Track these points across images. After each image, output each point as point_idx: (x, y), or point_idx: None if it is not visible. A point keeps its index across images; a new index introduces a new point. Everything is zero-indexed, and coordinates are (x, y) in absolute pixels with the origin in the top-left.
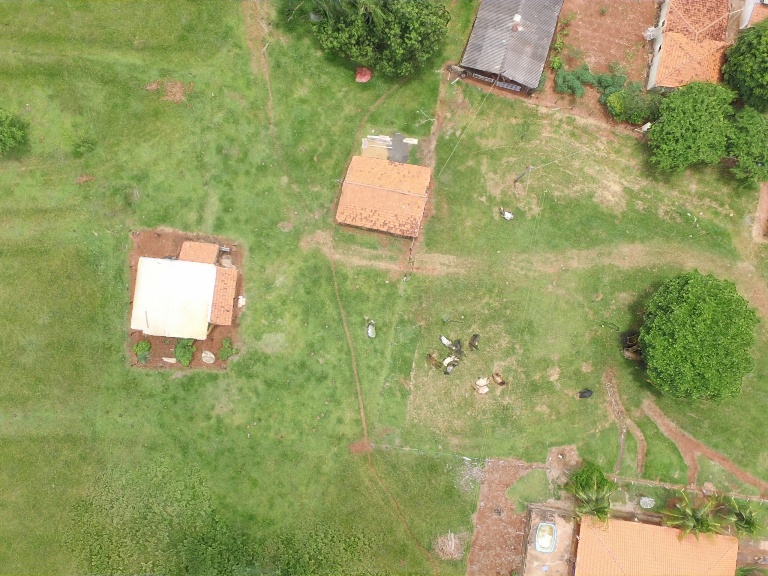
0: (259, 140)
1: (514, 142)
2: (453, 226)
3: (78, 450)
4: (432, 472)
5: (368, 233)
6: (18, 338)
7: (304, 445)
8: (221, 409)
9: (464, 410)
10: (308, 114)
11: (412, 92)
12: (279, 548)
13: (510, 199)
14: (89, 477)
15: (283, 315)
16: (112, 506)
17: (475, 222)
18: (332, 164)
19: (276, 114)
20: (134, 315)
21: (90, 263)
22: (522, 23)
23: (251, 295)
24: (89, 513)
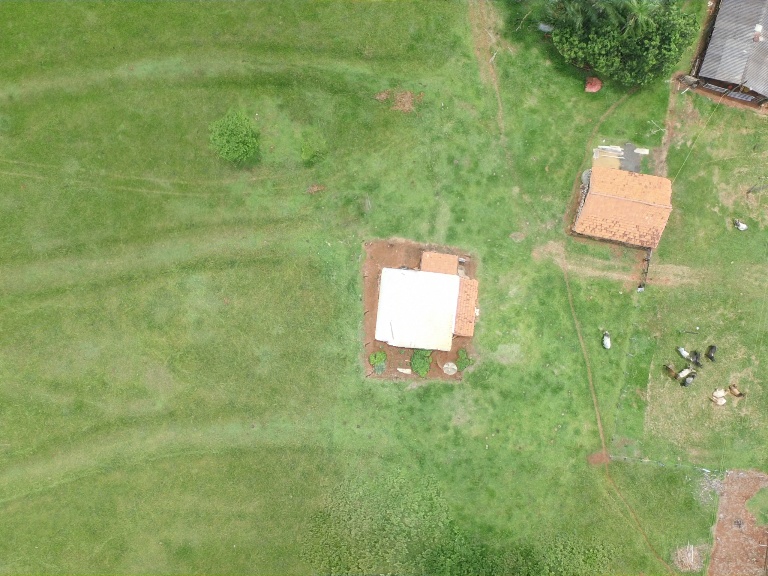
0: (490, 150)
1: (746, 152)
2: (686, 237)
3: (315, 461)
4: (671, 484)
5: (600, 244)
6: (253, 349)
7: (542, 456)
8: (458, 420)
9: (701, 422)
10: (539, 124)
11: (642, 102)
12: (518, 560)
13: (743, 210)
14: (326, 488)
15: (517, 326)
16: (350, 517)
17: (708, 233)
18: (564, 174)
19: (507, 124)
20: (378, 326)
21: (322, 273)
22: (763, 33)
23: (485, 306)
24: (327, 524)
